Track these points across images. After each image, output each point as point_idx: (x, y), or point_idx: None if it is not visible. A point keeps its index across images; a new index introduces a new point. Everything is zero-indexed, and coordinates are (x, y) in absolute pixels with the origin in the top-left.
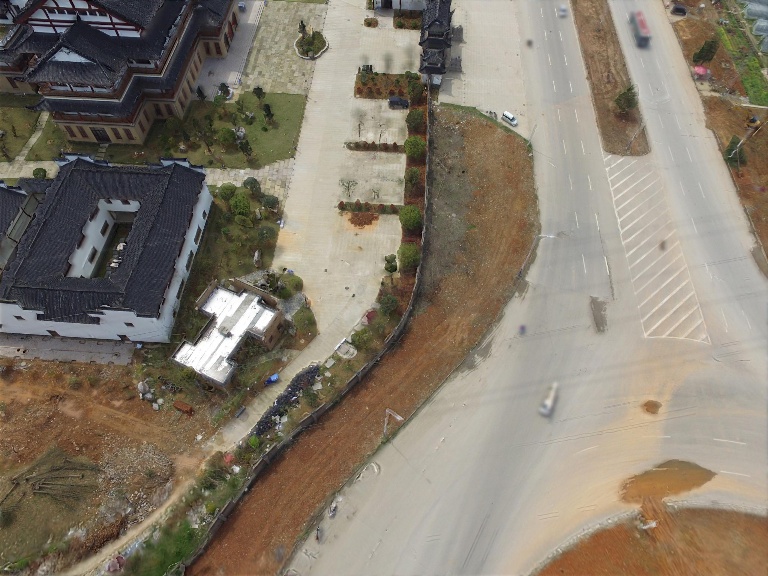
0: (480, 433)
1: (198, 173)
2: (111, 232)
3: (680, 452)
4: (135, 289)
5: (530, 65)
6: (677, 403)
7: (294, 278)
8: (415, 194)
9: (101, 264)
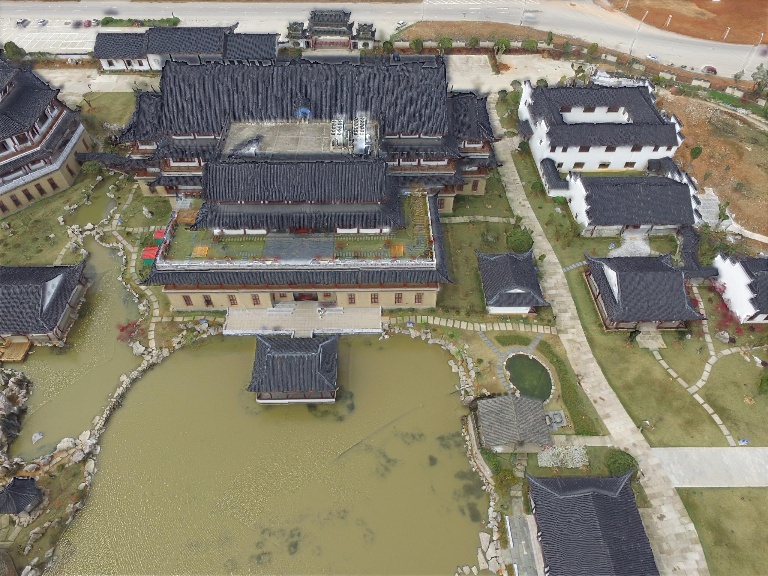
0: None
1: None
2: None
3: (589, 2)
4: None
5: None
6: (568, 0)
7: (565, 77)
8: None
9: None
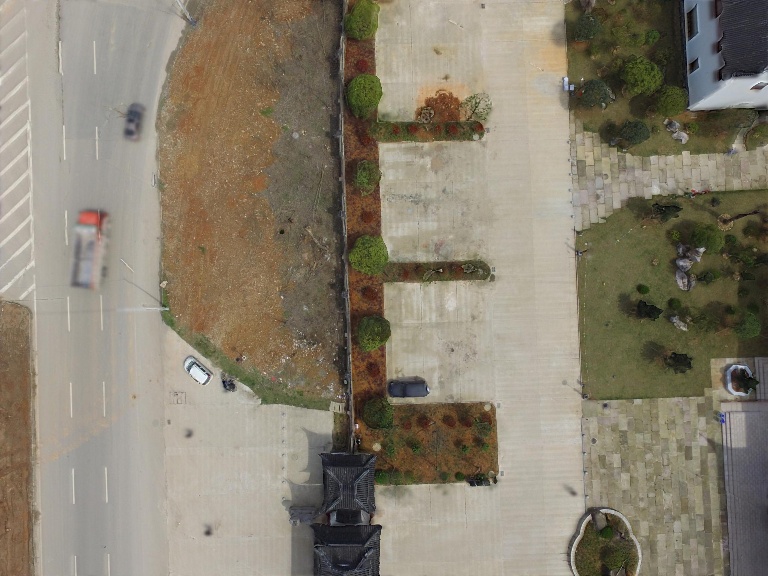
0: None
1: None
2: None
3: None
4: None
5: (151, 549)
6: None
7: None
8: None
9: None
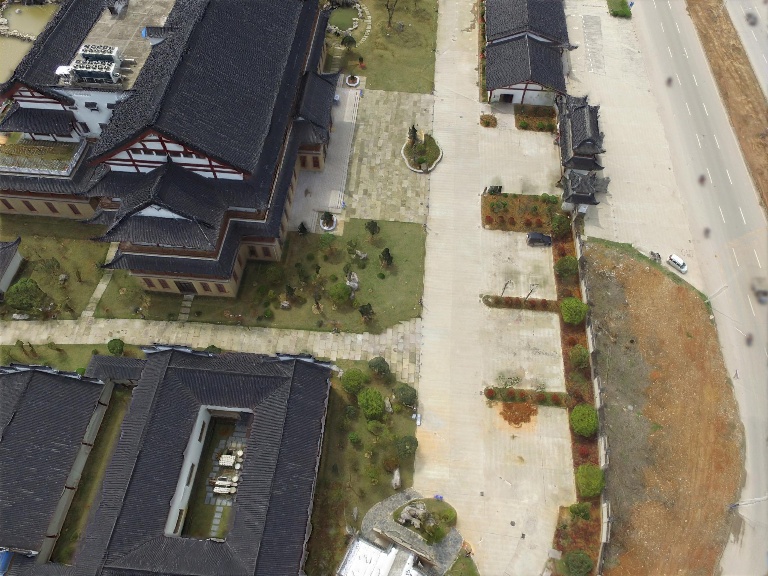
0: None
1: (322, 368)
2: (208, 431)
3: None
4: (264, 568)
5: (687, 183)
6: None
7: (449, 515)
8: (578, 376)
9: (199, 481)
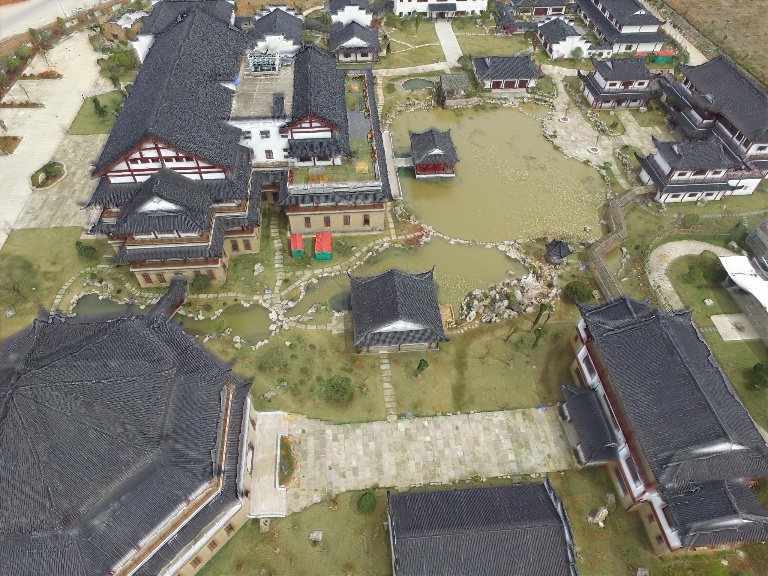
0: (25, 21)
1: None
2: None
3: None
4: None
5: None
6: None
7: None
8: None
9: None
